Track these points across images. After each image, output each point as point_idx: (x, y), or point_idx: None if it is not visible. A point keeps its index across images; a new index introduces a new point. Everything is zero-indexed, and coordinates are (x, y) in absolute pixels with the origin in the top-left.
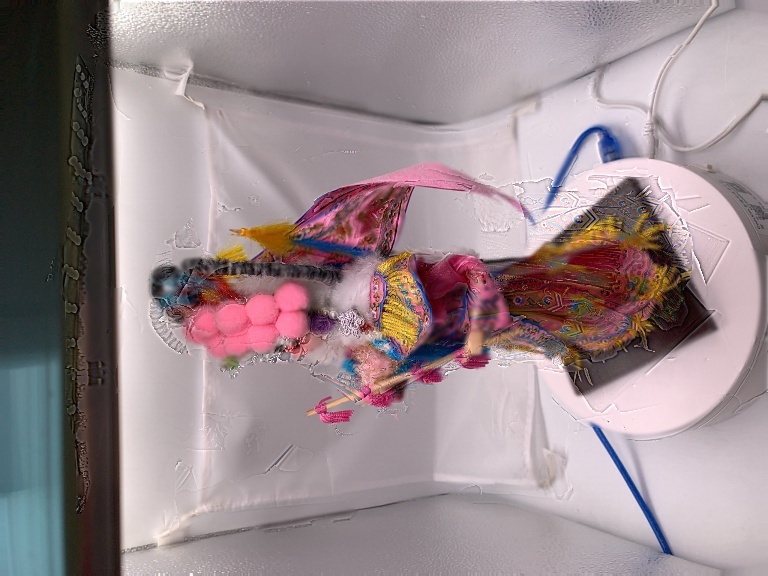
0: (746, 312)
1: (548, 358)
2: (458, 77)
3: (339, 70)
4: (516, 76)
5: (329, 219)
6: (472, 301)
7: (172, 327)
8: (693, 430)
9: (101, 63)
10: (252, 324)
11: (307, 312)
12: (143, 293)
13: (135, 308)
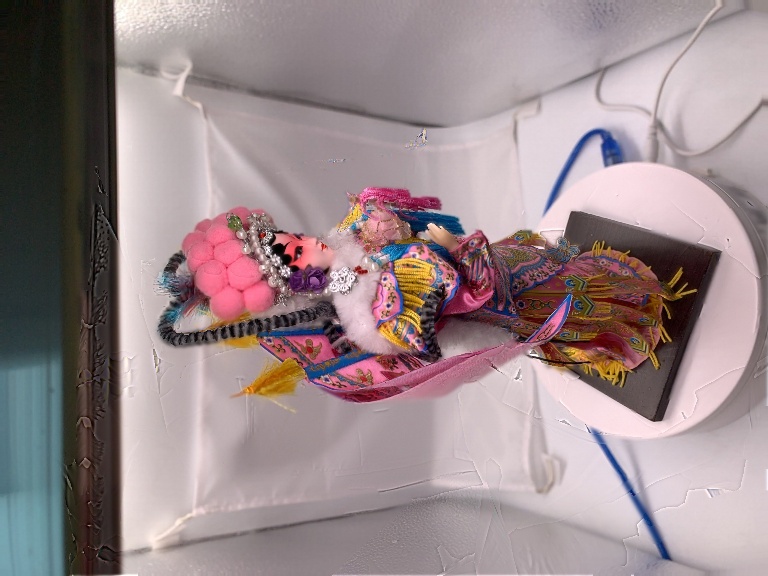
0: (573, 192)
1: None
2: None
3: None
4: None
5: None
6: None
7: (183, 306)
8: (687, 170)
9: None
10: None
11: None
12: None
13: None
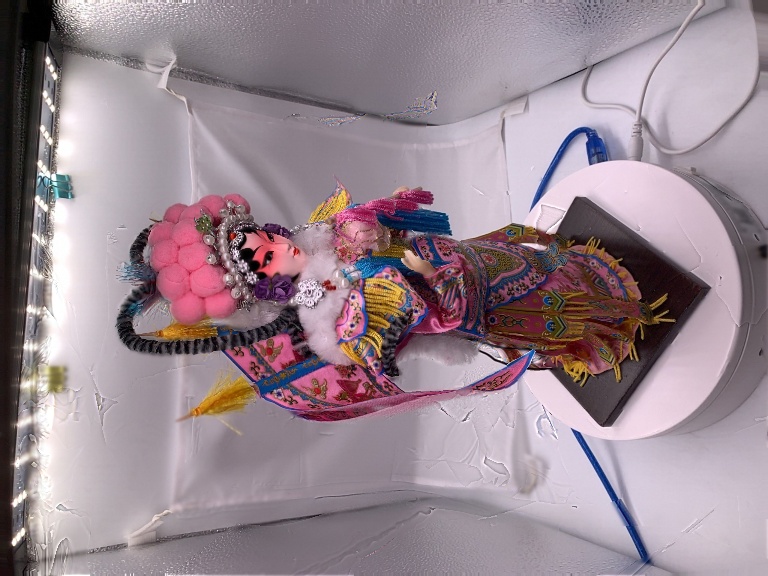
0: (583, 174)
1: None
2: None
3: (314, 535)
4: None
5: None
6: None
7: (142, 306)
8: (703, 188)
9: None
10: None
11: None
12: (106, 324)
13: (104, 358)
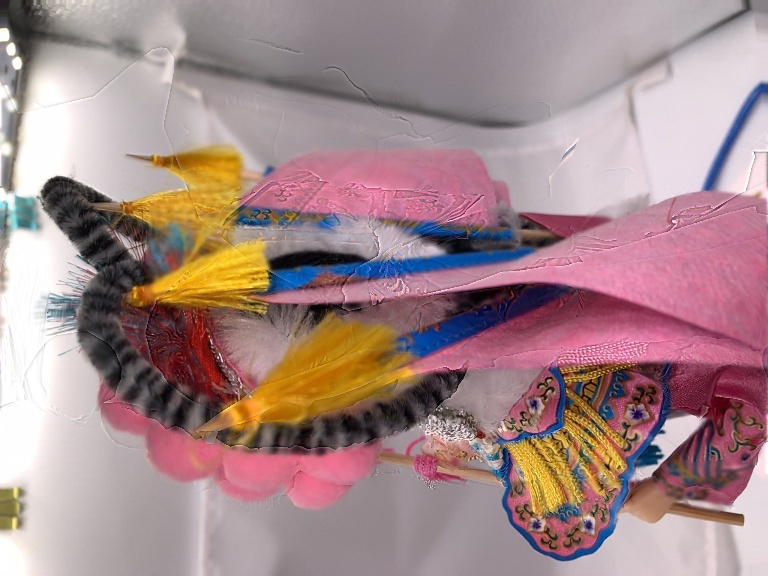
0: None
1: None
2: None
3: None
4: None
5: None
6: (693, 458)
7: None
8: None
9: None
10: None
11: None
12: None
13: None
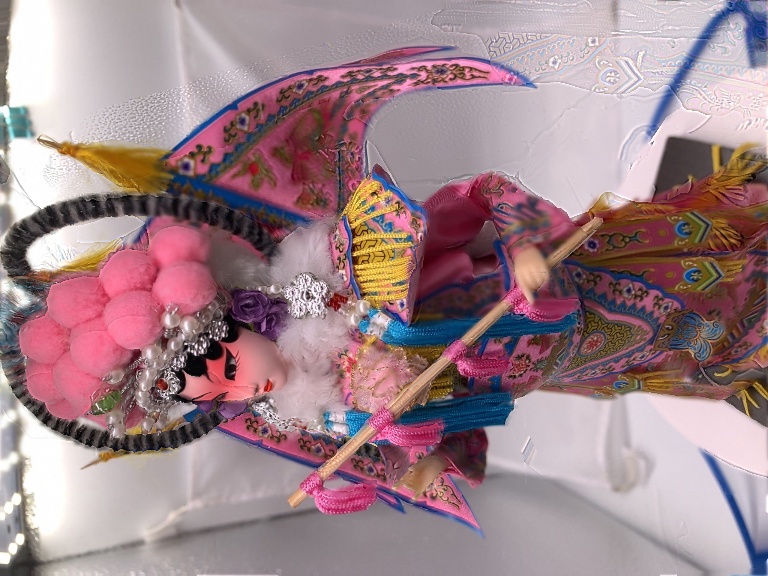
0: None
1: (686, 368)
2: (457, 121)
3: None
4: (524, 103)
5: (235, 142)
6: (504, 224)
7: None
8: None
9: (16, 153)
10: (109, 297)
11: (214, 274)
12: None
13: None
